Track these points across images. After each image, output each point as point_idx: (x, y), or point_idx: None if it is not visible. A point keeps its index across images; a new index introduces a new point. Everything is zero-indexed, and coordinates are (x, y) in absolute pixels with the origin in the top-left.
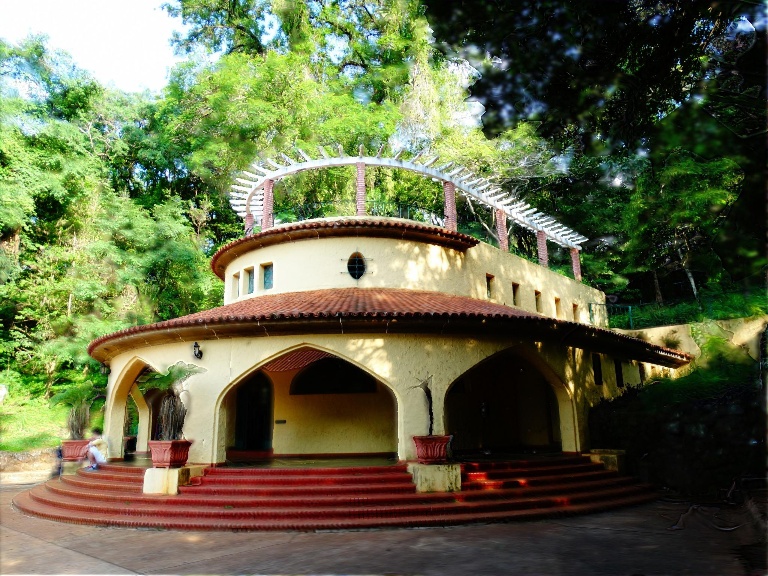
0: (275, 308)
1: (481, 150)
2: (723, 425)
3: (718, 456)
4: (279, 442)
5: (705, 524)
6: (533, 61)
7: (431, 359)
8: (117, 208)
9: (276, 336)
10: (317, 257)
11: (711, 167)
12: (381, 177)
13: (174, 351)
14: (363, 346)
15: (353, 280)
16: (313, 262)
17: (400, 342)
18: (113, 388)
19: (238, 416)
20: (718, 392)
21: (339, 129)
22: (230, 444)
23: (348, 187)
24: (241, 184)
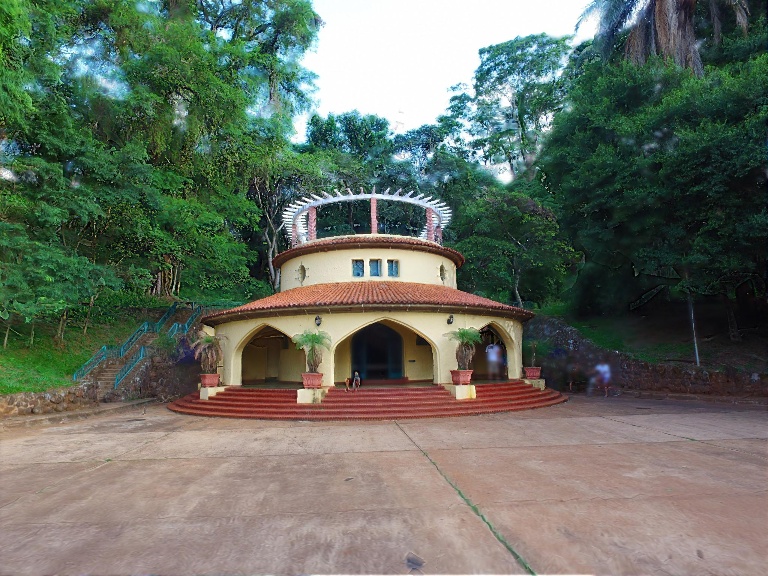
0: (471, 299)
1: (318, 172)
2: (560, 363)
3: (560, 375)
4: (412, 373)
5: (610, 394)
6: (701, 265)
7: (519, 332)
8: (67, 129)
9: (484, 316)
10: (427, 264)
11: (500, 244)
12: (222, 159)
13: (429, 318)
14: (509, 325)
15: (442, 281)
16: (425, 266)
17: (515, 324)
18: (344, 336)
19: (355, 357)
20: (547, 350)
21: (257, 125)
22: (351, 376)
23: (248, 173)
24: (155, 137)
